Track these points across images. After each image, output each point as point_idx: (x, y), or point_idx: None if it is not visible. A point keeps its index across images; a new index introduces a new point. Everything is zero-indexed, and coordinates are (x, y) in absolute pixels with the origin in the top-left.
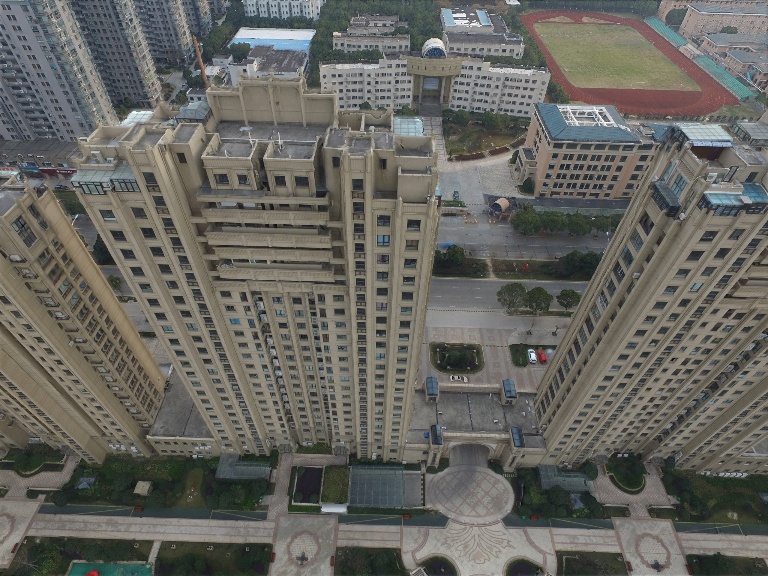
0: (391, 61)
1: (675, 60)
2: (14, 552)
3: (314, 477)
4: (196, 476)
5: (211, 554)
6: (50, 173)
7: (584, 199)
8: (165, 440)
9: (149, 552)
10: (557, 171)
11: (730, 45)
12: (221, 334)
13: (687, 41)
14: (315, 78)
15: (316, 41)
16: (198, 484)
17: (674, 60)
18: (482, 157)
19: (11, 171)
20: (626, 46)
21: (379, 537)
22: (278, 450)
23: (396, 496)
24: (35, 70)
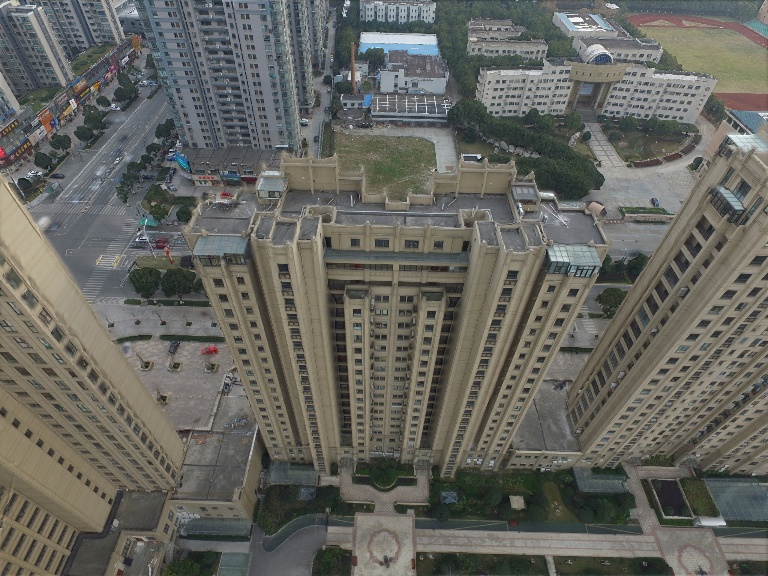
0: (556, 67)
1: None
2: (414, 568)
3: (672, 490)
4: (552, 490)
5: (608, 569)
6: (249, 181)
7: None
8: (529, 454)
9: (546, 567)
10: None
11: None
12: (727, 353)
13: None
14: (468, 84)
15: (445, 46)
16: (558, 498)
17: None
18: (659, 163)
19: (211, 179)
20: (740, 50)
21: (763, 550)
22: (622, 463)
23: (766, 509)
24: (253, 79)
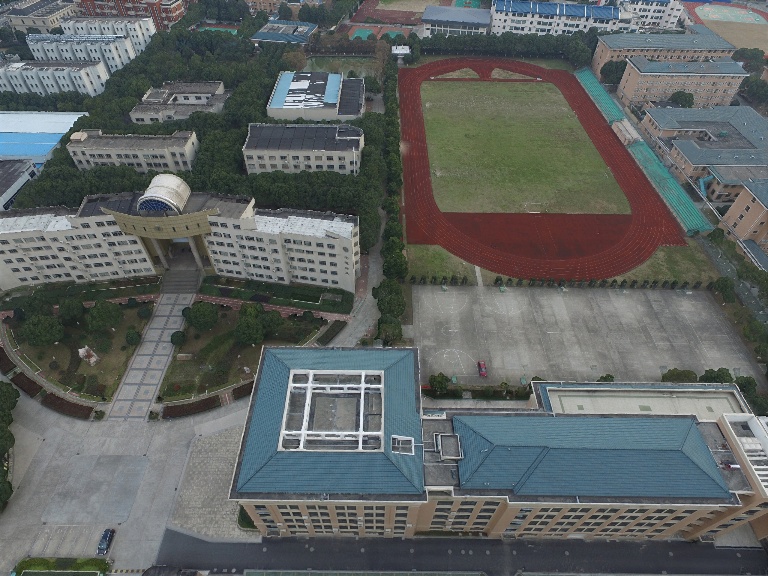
0: (84, 219)
1: (602, 148)
2: None
3: None
4: None
5: None
6: None
7: (357, 539)
8: None
9: None
10: (280, 517)
11: (679, 128)
12: None
13: (625, 110)
14: None
15: (65, 139)
16: None
17: (601, 148)
18: (214, 407)
19: None
20: (538, 122)
21: None
22: None
23: None
24: None
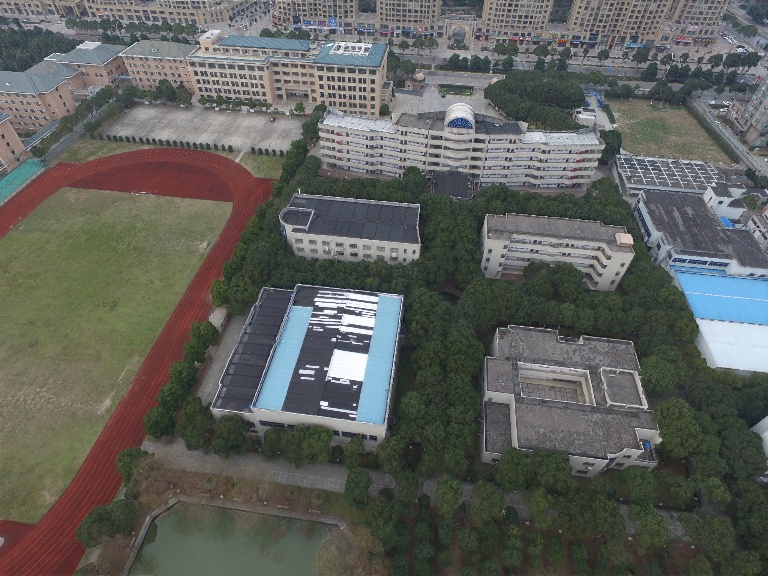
0: (513, 123)
1: None
2: None
3: None
4: None
5: None
6: None
7: None
8: None
9: None
10: None
11: None
12: None
13: None
14: None
15: None
16: None
17: None
18: None
19: None
20: None
21: None
22: None
23: None
24: None
